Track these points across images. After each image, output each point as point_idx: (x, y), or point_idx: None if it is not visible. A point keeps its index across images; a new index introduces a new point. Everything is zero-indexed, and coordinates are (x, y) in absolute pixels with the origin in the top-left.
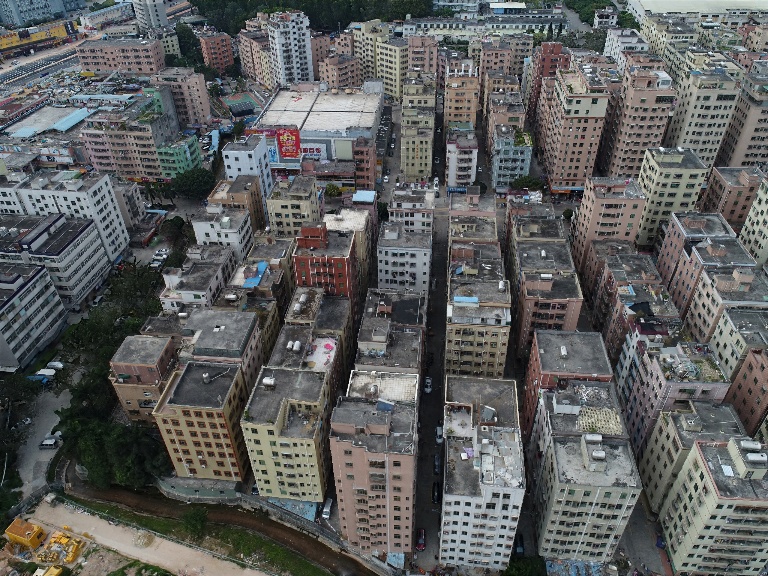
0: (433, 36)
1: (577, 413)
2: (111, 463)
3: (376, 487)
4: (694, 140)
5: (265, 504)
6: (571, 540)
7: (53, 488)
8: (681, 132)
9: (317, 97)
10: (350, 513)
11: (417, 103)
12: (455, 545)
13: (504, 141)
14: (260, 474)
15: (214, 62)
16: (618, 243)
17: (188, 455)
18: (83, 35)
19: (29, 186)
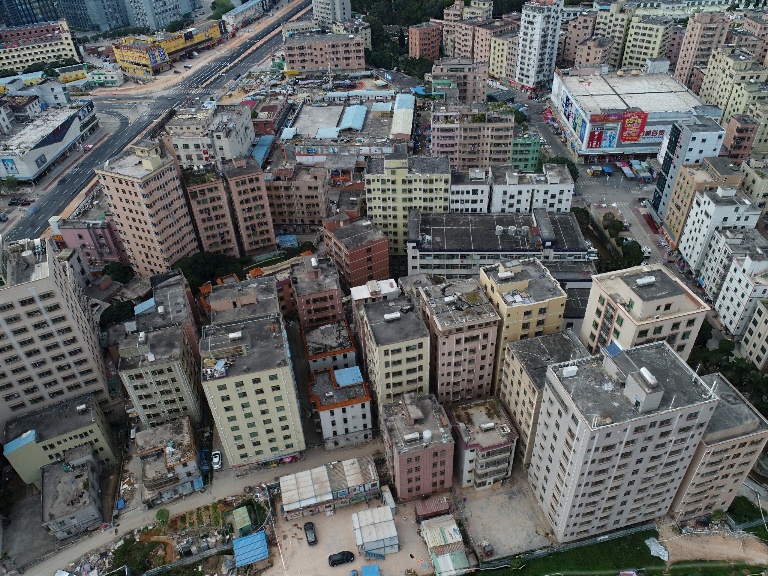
0: (721, 12)
1: None
2: None
3: None
4: None
5: None
6: None
7: None
8: None
9: (605, 80)
10: None
11: (748, 79)
12: None
13: None
14: None
15: (423, 53)
16: None
17: None
18: (233, 35)
19: (497, 182)
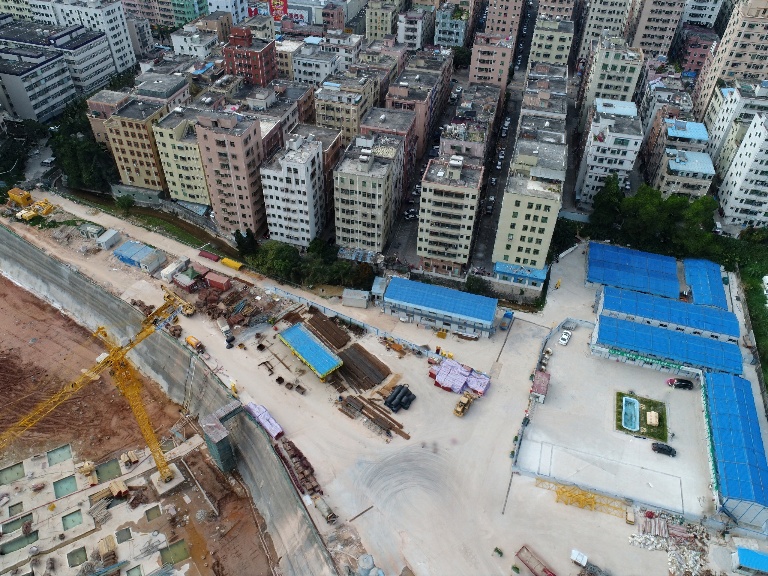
0: None
1: (370, 147)
2: (81, 169)
3: (224, 166)
4: (597, 25)
5: (175, 206)
6: (352, 229)
7: (44, 183)
8: (588, 17)
9: None
10: (216, 197)
11: None
12: (276, 220)
13: (442, 14)
14: (169, 176)
15: None
16: (491, 86)
17: (128, 163)
18: None
19: (62, 3)
